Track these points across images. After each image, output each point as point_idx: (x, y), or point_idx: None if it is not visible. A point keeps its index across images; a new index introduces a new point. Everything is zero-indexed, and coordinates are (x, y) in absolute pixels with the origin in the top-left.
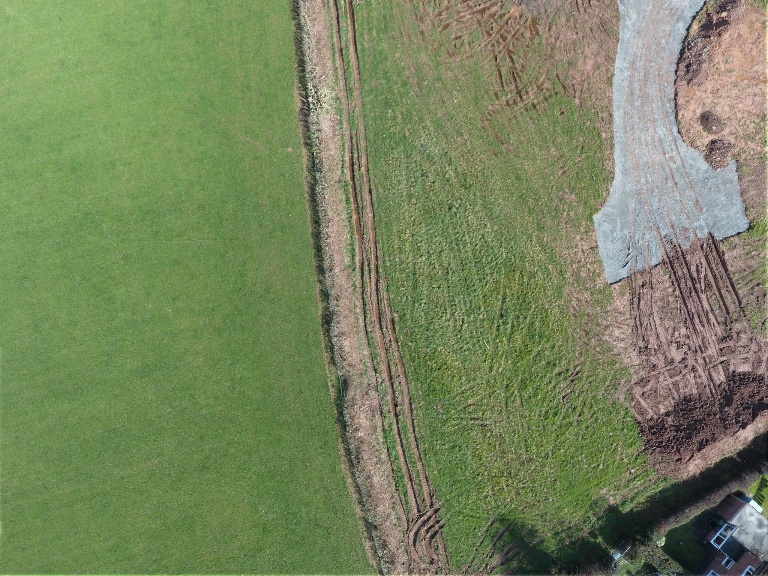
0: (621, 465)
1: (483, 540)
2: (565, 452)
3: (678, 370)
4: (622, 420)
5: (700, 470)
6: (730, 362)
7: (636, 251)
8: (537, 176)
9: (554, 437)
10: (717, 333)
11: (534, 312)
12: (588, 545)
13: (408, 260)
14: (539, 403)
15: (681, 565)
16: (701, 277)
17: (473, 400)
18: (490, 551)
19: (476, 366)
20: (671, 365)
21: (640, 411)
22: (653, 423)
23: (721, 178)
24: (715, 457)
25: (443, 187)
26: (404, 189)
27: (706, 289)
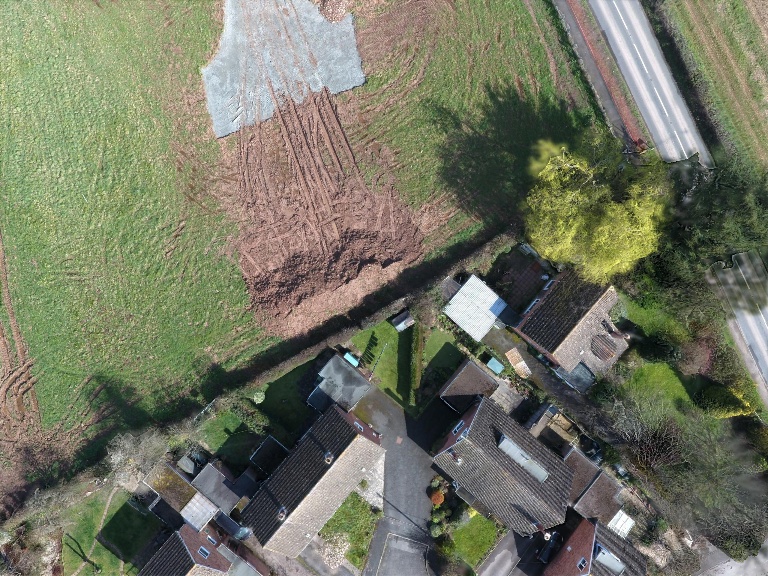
0: (227, 323)
1: (79, 397)
2: (167, 309)
3: (288, 227)
4: (229, 277)
5: (308, 328)
6: (344, 219)
7: (246, 105)
8: (141, 27)
9: (156, 293)
10: (330, 189)
11: (136, 166)
12: (187, 403)
13: (3, 111)
14: (140, 258)
15: (273, 420)
16: (312, 131)
17: (71, 255)
18: (86, 409)
19: (74, 220)
20: (281, 221)
21: (247, 268)
22: (259, 280)
23: (336, 31)
24: (321, 314)
25: (41, 37)
26: (1, 39)
27: (318, 144)
